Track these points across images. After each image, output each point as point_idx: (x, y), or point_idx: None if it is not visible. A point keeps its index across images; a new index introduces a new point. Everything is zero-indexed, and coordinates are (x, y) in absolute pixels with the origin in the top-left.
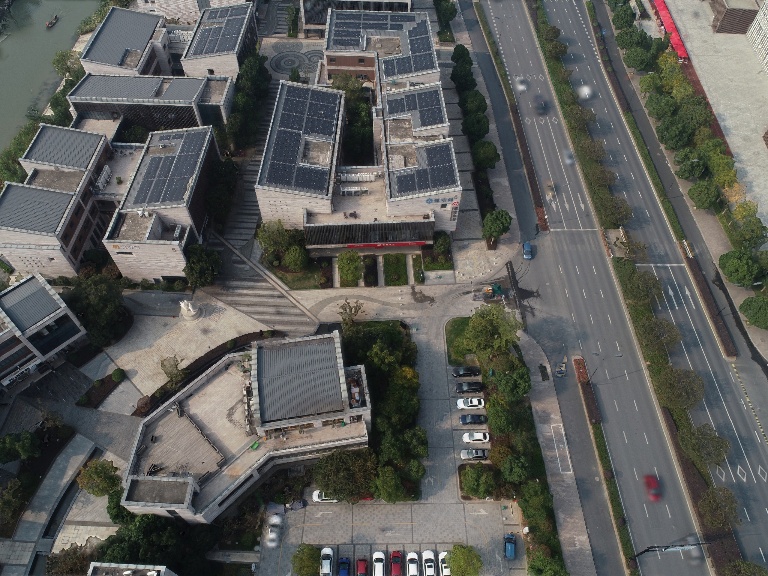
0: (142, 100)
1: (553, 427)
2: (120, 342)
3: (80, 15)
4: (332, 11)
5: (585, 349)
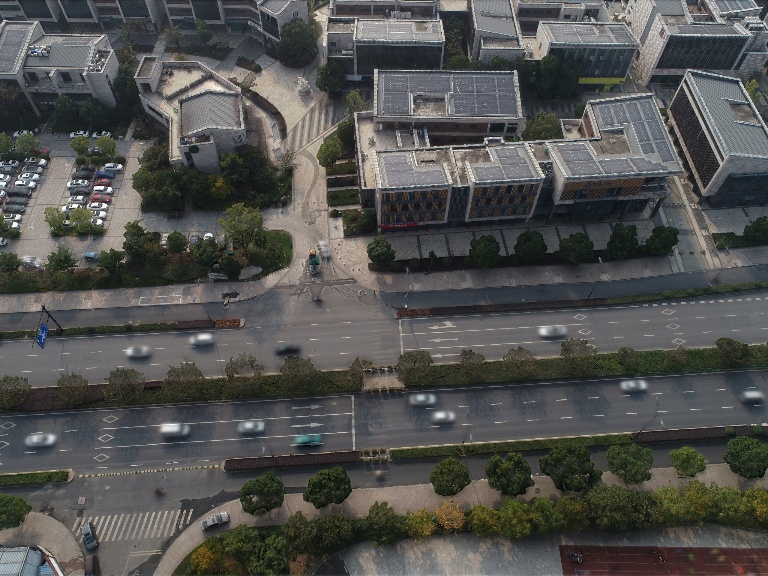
0: (473, 6)
1: (179, 296)
2: (283, 66)
3: None
4: (651, 97)
5: (251, 330)
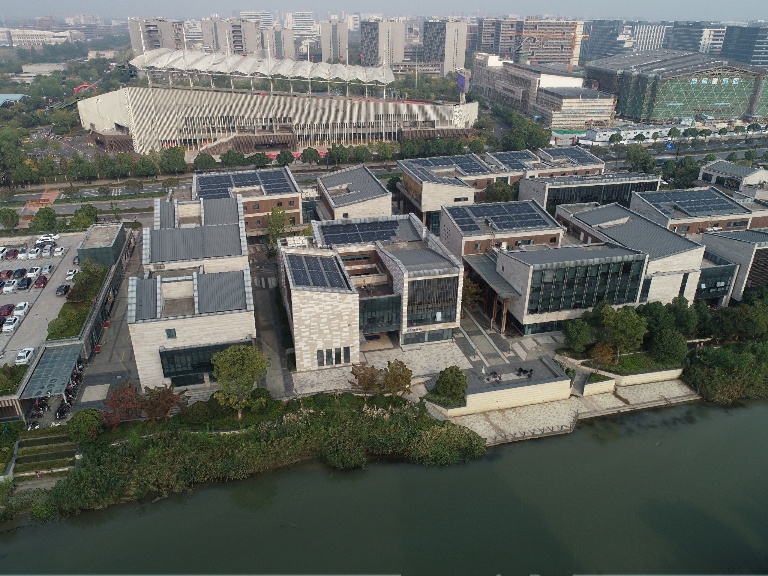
0: None
1: None
2: None
3: (417, 484)
4: None
5: None
